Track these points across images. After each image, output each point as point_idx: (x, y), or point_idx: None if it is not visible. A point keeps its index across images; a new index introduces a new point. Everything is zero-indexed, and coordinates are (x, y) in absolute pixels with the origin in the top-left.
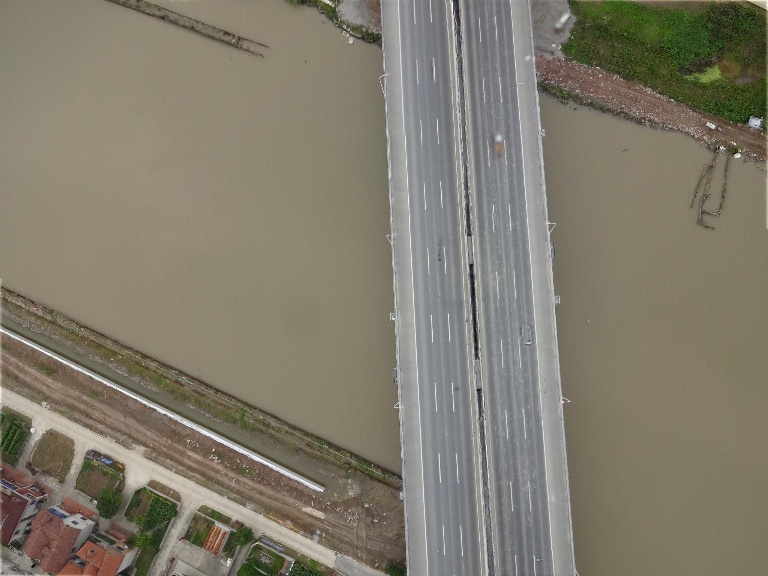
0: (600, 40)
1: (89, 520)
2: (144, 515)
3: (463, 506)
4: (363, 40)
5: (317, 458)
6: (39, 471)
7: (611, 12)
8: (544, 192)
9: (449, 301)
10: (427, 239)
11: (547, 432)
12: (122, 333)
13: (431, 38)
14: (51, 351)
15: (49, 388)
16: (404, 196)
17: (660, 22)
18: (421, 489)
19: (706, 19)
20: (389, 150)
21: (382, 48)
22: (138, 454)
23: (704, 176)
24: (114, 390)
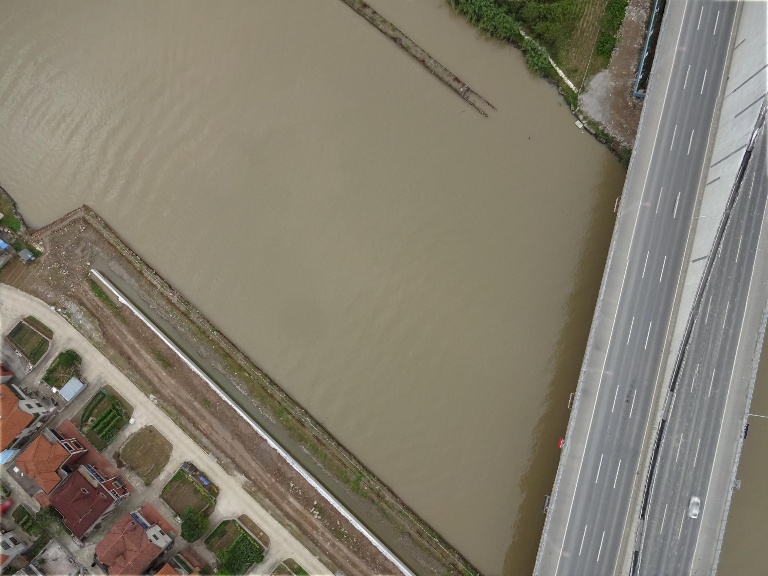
0: None
1: (167, 536)
2: (228, 550)
3: None
4: (595, 137)
5: (422, 548)
6: (126, 465)
7: None
8: (755, 370)
9: (625, 447)
10: (621, 375)
11: None
12: (256, 351)
13: (683, 171)
14: (173, 342)
15: (161, 381)
16: (610, 323)
17: None
18: None
19: None
20: (608, 270)
21: (630, 163)
22: (237, 483)
23: None
24: (228, 406)
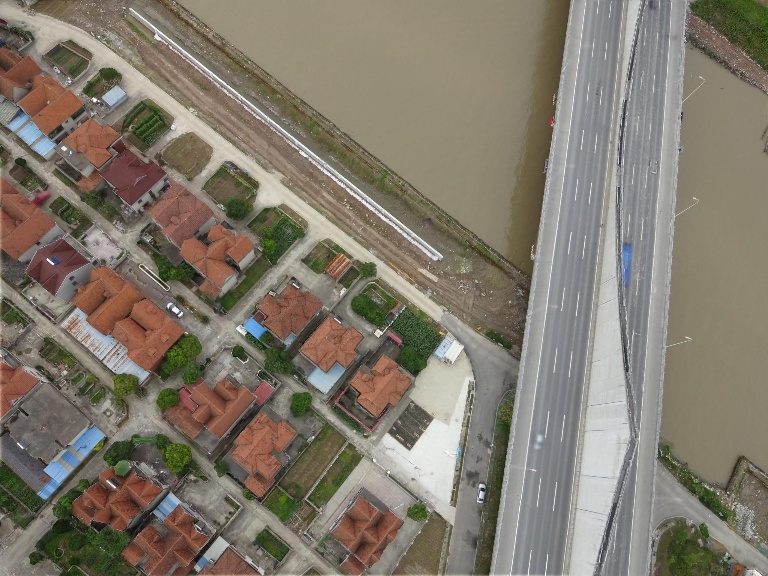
0: (718, 9)
1: None
2: (272, 228)
3: (584, 277)
4: None
5: (442, 231)
6: (168, 165)
7: None
8: None
9: (599, 124)
10: (590, 77)
11: (658, 240)
12: (286, 78)
13: None
14: None
15: (199, 100)
16: (578, 42)
17: (760, 13)
18: (551, 255)
19: None
20: (572, 8)
21: None
22: (276, 178)
23: None
24: (262, 123)
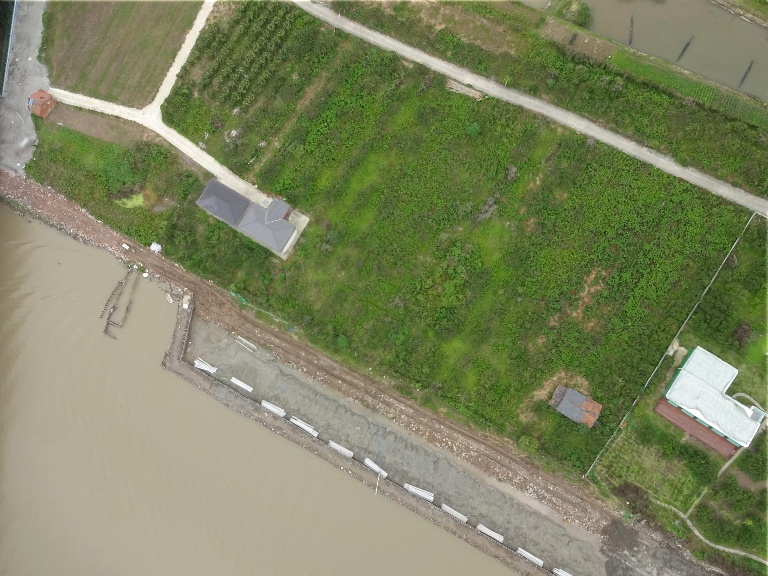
0: (51, 164)
1: None
2: None
3: None
4: None
5: None
6: None
7: (62, 140)
8: None
9: None
10: None
11: None
12: None
13: None
14: None
15: None
16: None
17: (96, 153)
18: None
19: (130, 154)
20: None
21: None
22: None
23: (115, 291)
24: None
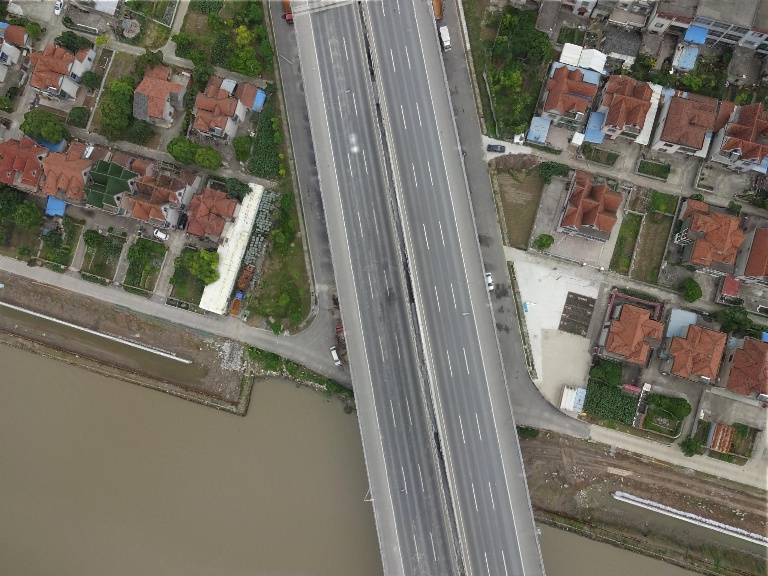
0: None
1: None
2: None
3: (478, 531)
4: None
5: (626, 528)
6: None
7: None
8: None
9: None
10: None
11: None
12: None
13: None
14: None
15: None
16: None
17: None
18: (521, 542)
19: None
20: None
21: None
22: None
23: None
24: None
